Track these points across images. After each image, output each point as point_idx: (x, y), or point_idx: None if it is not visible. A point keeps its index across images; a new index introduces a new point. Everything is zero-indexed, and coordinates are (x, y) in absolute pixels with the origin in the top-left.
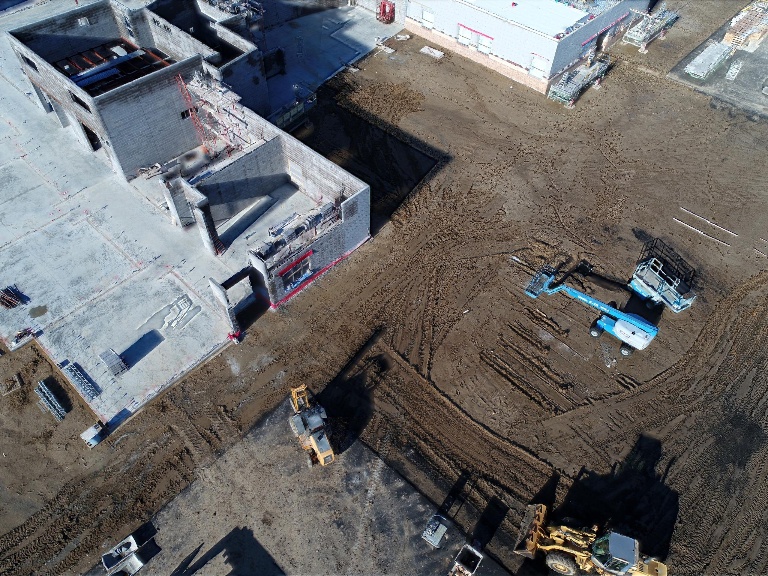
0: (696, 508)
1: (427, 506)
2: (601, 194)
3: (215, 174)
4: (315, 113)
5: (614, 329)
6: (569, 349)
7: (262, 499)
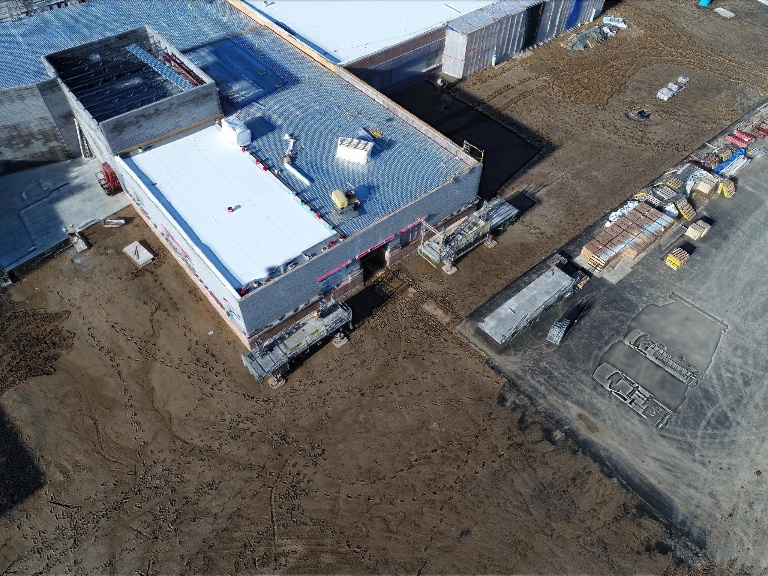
0: None
1: None
2: None
3: None
4: None
5: None
6: None
7: None
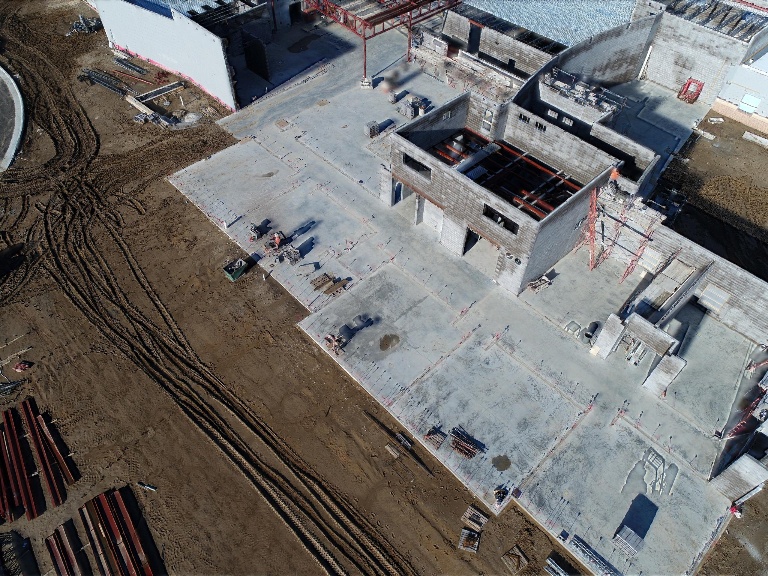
0: None
1: None
2: None
3: (671, 310)
4: None
5: None
6: None
7: None
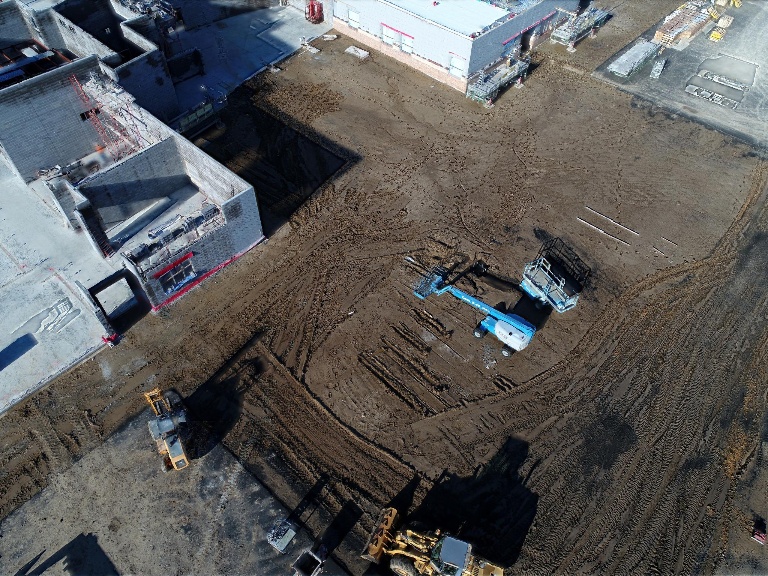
0: (554, 511)
1: (279, 511)
2: (507, 194)
3: (100, 176)
4: (229, 114)
5: (495, 330)
6: (450, 350)
7: (112, 505)
